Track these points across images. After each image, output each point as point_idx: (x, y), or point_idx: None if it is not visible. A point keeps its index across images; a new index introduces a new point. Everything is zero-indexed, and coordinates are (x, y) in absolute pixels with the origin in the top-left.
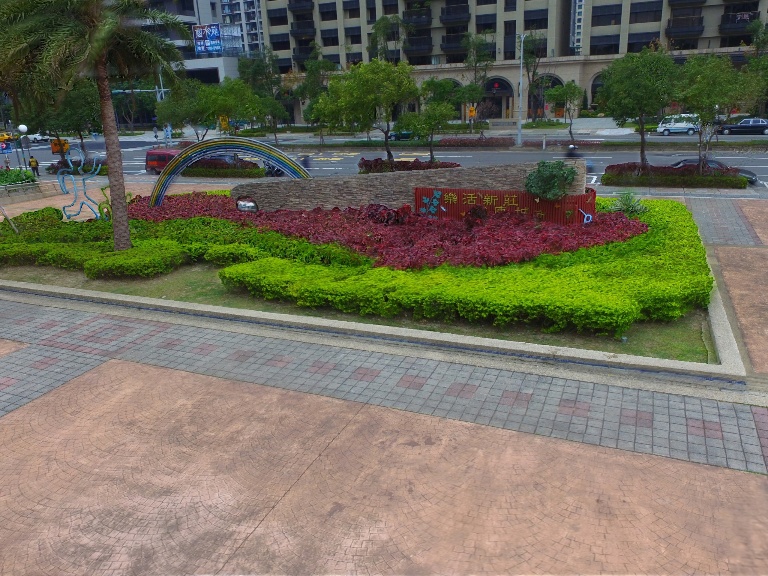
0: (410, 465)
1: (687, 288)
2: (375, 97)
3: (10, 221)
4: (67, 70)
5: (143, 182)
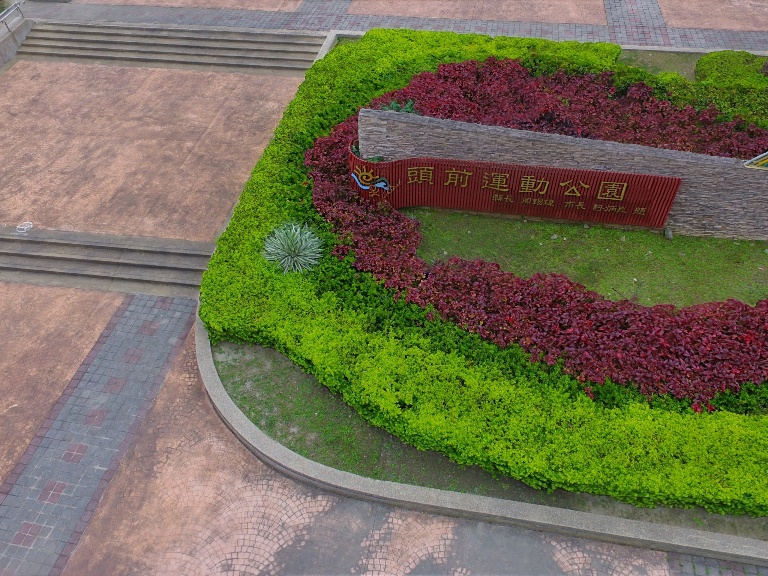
0: (446, 5)
1: (331, 53)
2: None
3: None
4: None
5: None
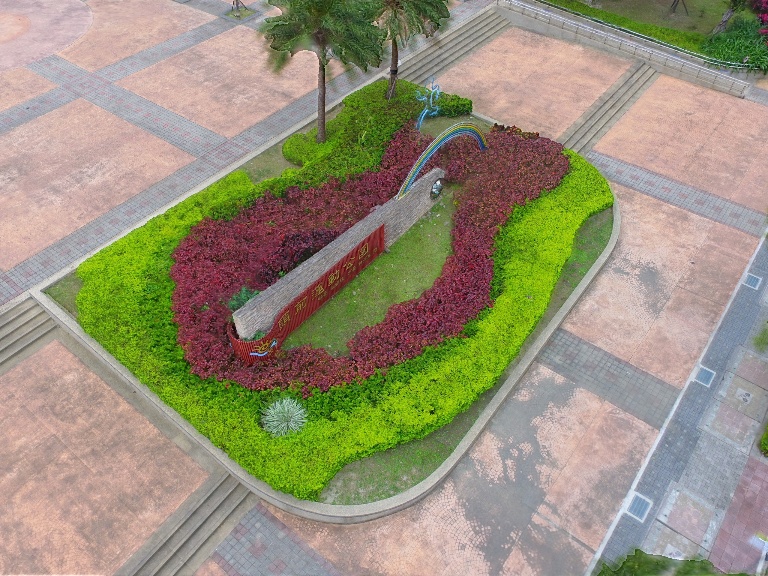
0: None
1: None
2: None
3: None
4: None
5: None
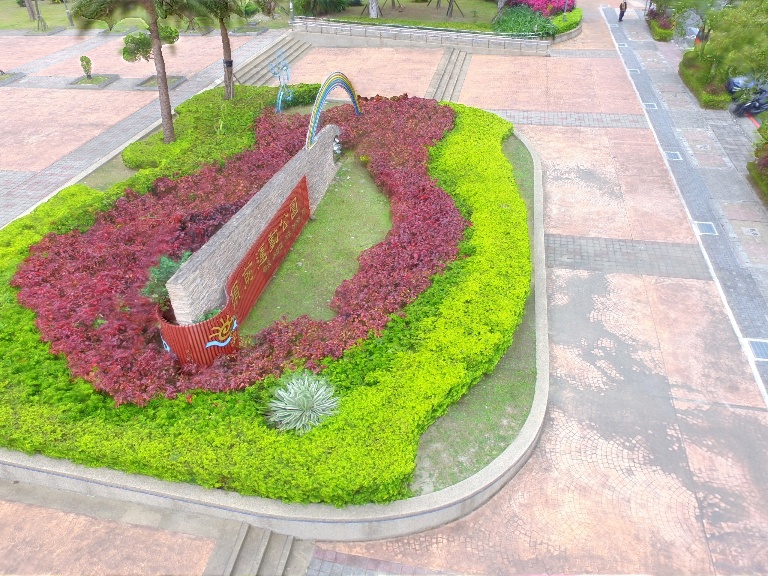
0: None
1: None
2: (739, 56)
3: (232, 92)
4: (107, 21)
5: (626, 65)
